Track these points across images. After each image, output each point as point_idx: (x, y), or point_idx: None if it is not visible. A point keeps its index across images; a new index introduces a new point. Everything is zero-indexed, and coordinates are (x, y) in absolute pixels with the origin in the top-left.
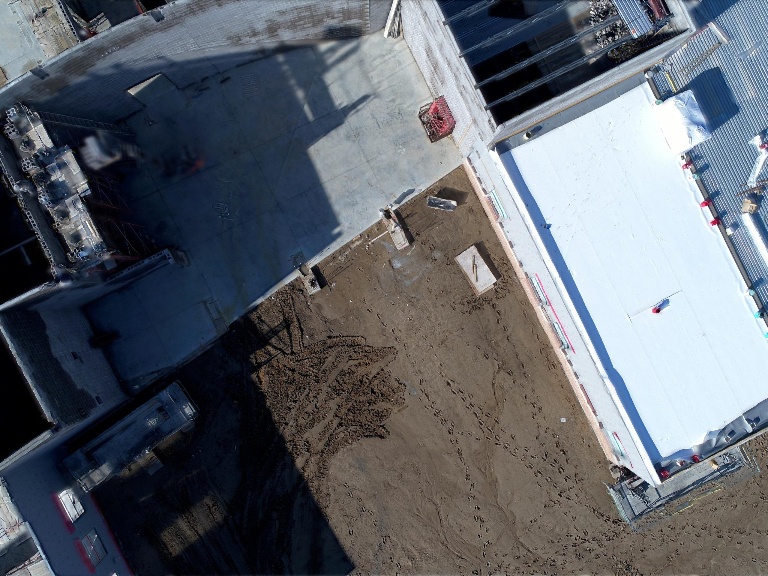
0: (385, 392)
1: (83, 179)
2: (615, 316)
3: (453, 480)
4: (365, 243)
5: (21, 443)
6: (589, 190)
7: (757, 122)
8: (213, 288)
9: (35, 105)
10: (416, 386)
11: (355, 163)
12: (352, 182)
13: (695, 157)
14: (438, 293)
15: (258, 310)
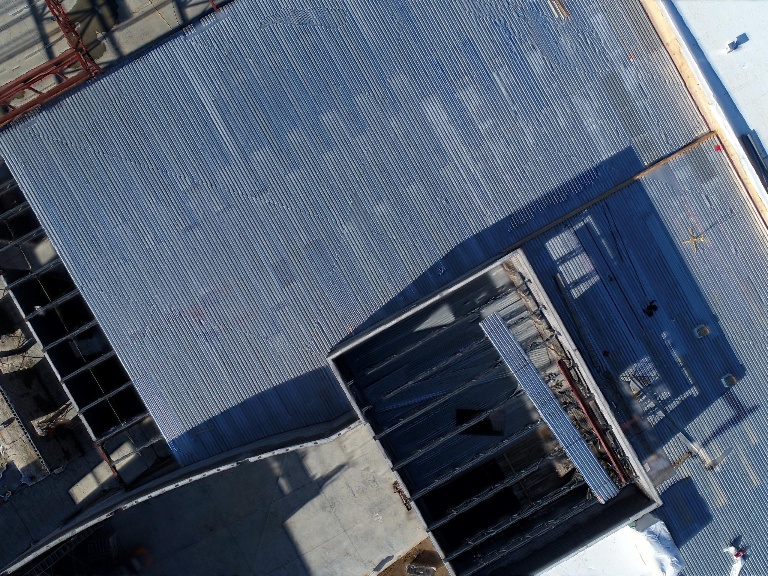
0: None
1: None
2: None
3: None
4: None
5: None
6: None
7: (732, 529)
8: None
9: None
10: None
11: (332, 533)
12: (330, 553)
13: None
14: None
15: None
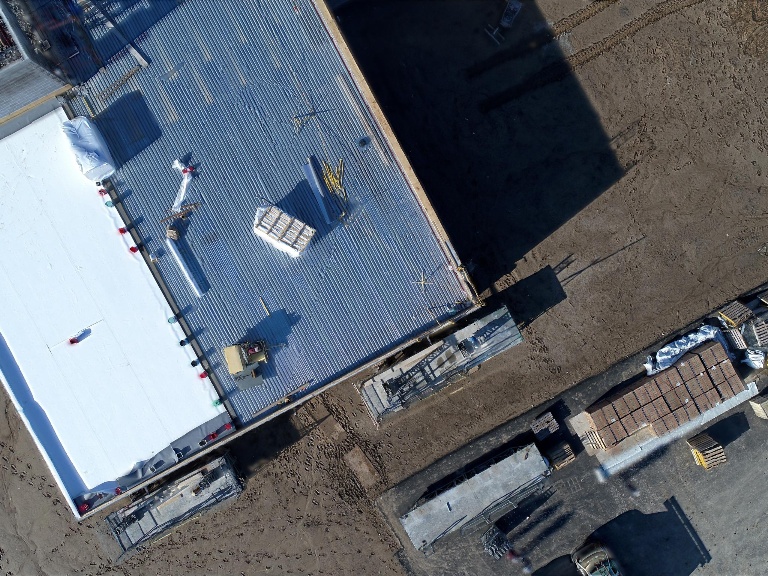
0: None
1: None
2: (34, 347)
3: None
4: None
5: None
6: (3, 219)
7: (181, 145)
8: None
9: None
10: None
11: None
12: None
13: (117, 183)
14: None
15: None
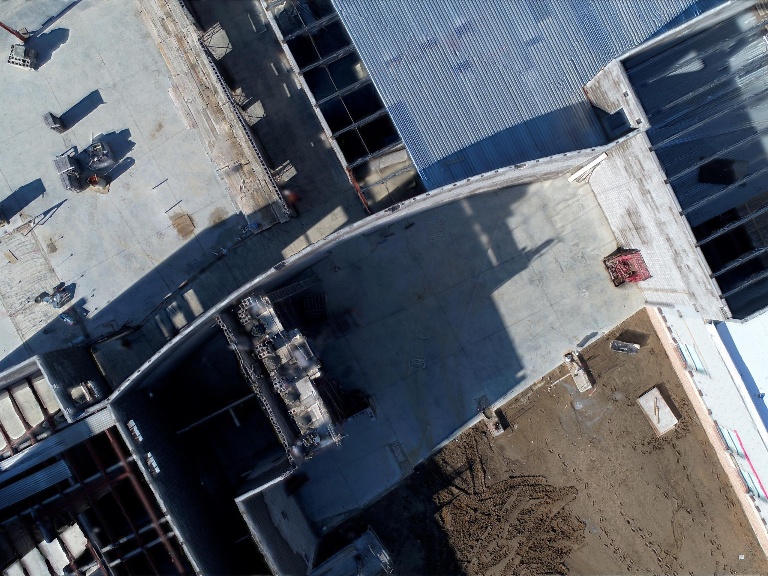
0: (565, 530)
1: (316, 365)
2: None
3: None
4: (547, 385)
5: None
6: None
7: None
8: (398, 431)
9: (264, 288)
10: (596, 524)
11: (538, 307)
12: (535, 326)
13: None
14: (619, 434)
15: (442, 452)
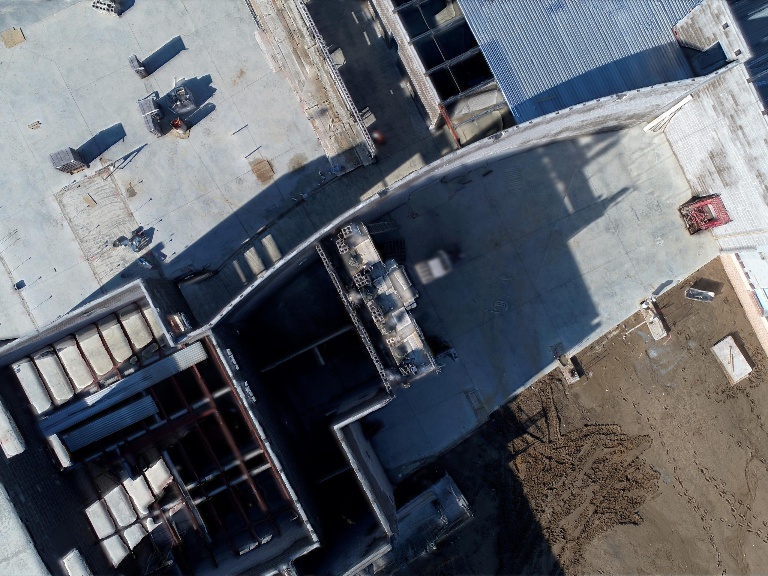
0: (639, 479)
1: (414, 294)
2: None
3: (705, 566)
4: (622, 333)
5: (337, 548)
6: None
7: None
8: (474, 378)
9: (361, 219)
10: (670, 474)
11: (614, 255)
12: (611, 273)
13: None
14: (693, 382)
15: (518, 400)
